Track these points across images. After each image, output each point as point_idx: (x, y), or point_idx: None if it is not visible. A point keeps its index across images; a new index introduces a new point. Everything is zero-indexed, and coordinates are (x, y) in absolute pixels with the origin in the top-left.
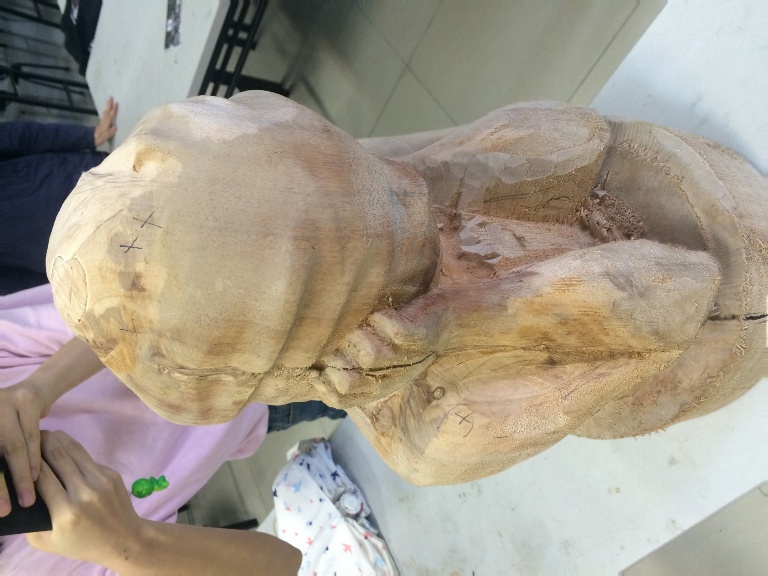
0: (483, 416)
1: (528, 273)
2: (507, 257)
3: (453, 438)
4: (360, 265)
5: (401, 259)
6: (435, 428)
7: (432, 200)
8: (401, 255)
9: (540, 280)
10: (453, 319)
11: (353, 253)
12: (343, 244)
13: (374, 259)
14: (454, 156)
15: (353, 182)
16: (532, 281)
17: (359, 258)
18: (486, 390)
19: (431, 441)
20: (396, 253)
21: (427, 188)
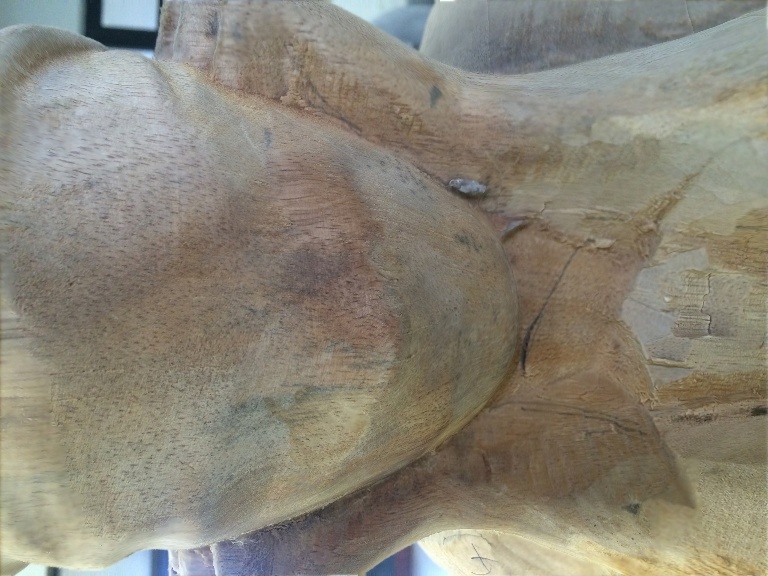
0: (508, 575)
1: (684, 479)
2: (707, 374)
3: (458, 563)
4: (110, 555)
5: (261, 507)
6: (442, 535)
7: (596, 197)
8: (260, 503)
9: (677, 531)
10: (434, 527)
11: (81, 550)
12: (47, 546)
13: (156, 539)
14: (684, 127)
15: (73, 446)
16: (659, 522)
17: (101, 552)
18: (536, 544)
19: (433, 541)
20: (233, 514)
21: (390, 370)
